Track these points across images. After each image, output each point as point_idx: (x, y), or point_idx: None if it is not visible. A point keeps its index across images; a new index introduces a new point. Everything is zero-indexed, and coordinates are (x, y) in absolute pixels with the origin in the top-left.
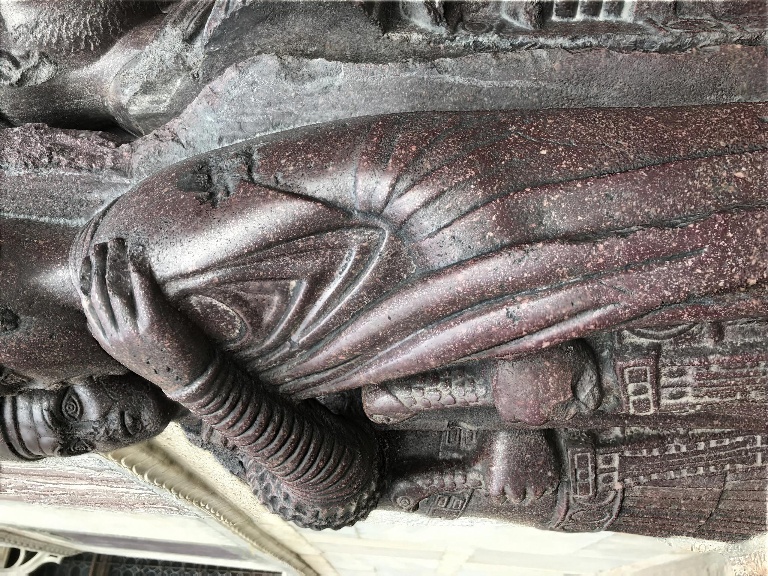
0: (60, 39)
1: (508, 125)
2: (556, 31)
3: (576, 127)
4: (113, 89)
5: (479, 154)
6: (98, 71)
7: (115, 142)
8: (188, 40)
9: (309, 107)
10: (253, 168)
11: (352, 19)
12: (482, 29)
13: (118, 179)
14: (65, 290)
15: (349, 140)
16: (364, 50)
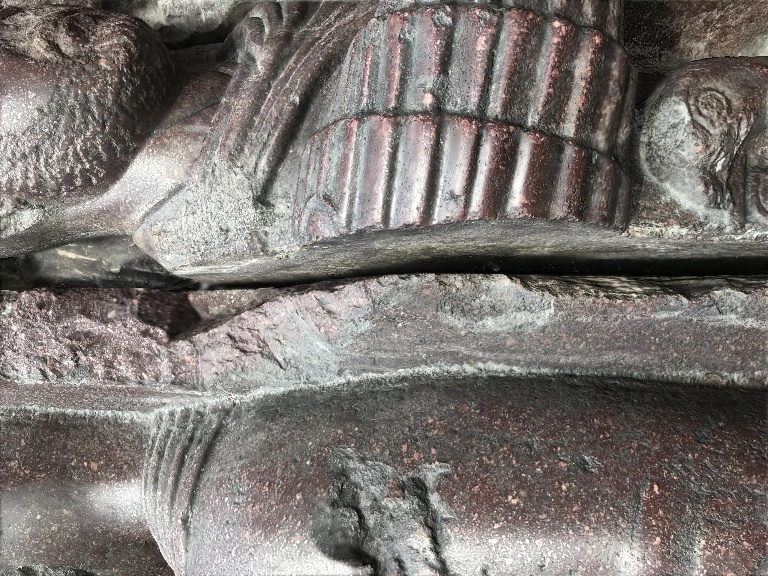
0: (40, 180)
1: None
2: None
3: None
4: (142, 240)
5: None
6: (109, 206)
7: (165, 326)
8: (261, 196)
9: (489, 348)
10: (439, 534)
11: (576, 228)
12: None
13: (185, 391)
14: (145, 530)
15: (606, 525)
16: (577, 242)
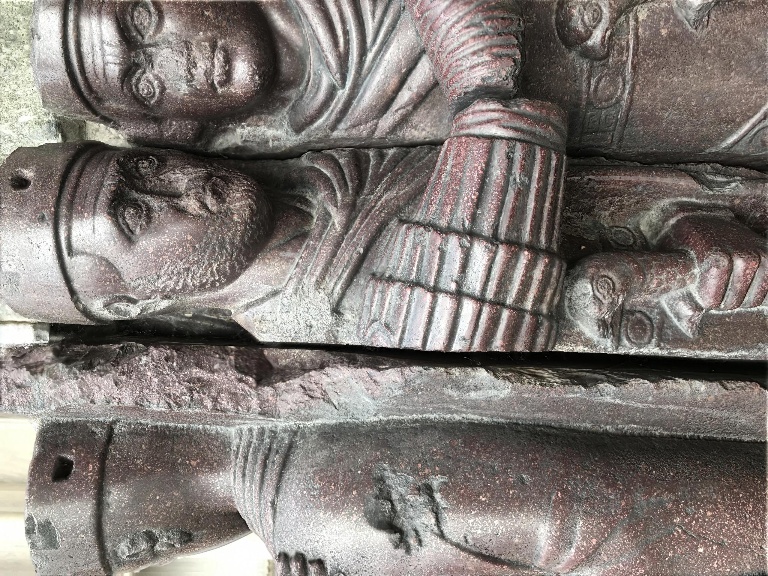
0: (185, 286)
1: (673, 516)
2: (713, 340)
3: (730, 525)
4: (243, 321)
5: (649, 553)
6: (222, 297)
7: (253, 375)
8: (335, 308)
9: (470, 407)
10: (440, 516)
11: None
12: (644, 336)
13: (265, 418)
14: (226, 506)
15: (532, 513)
16: None
